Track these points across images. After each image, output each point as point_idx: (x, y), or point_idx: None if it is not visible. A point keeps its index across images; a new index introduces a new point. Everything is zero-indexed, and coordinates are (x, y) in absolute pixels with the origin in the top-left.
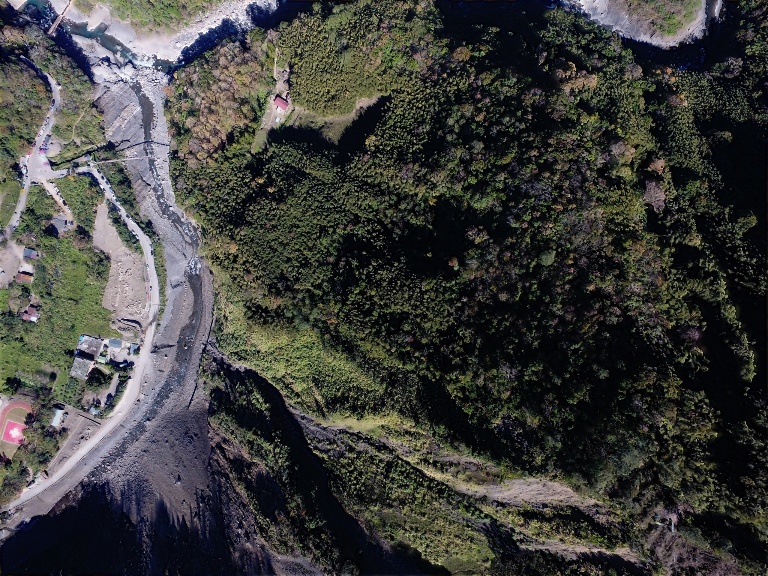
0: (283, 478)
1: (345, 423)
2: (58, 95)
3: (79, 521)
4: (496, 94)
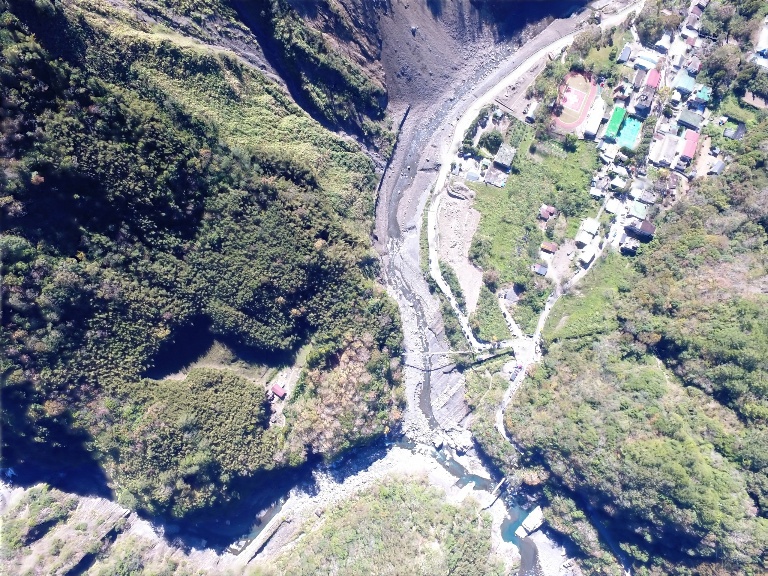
0: (277, 4)
1: (198, 46)
2: (498, 417)
3: (526, 8)
4: (6, 357)
